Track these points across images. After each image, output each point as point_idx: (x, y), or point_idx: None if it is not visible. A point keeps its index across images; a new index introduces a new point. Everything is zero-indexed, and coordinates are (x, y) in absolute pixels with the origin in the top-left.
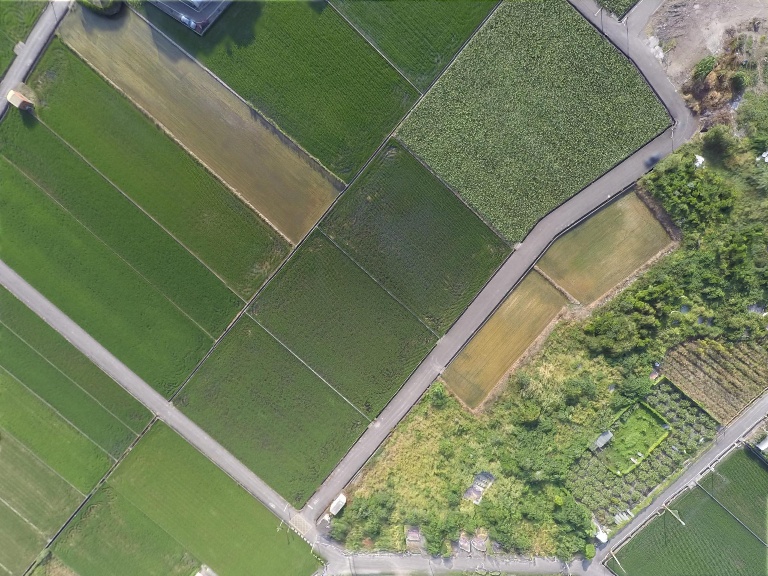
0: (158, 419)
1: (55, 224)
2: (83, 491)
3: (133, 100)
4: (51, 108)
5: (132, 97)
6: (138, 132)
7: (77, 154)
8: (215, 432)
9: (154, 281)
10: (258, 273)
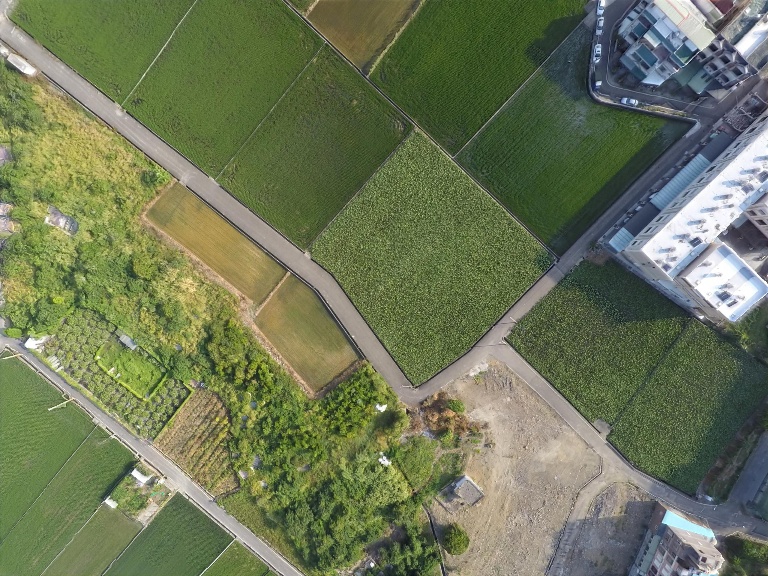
0: None
1: None
2: None
3: None
4: None
5: None
6: None
7: None
8: None
9: None
10: None
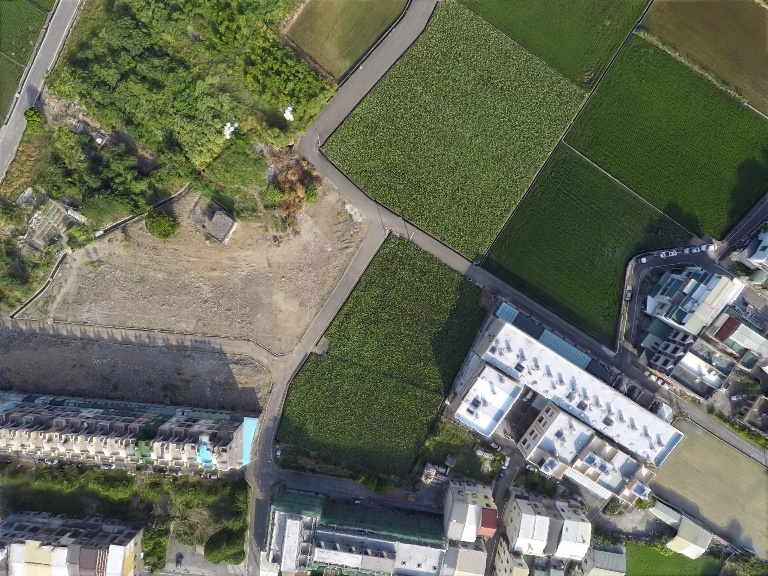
0: None
1: None
2: None
3: None
4: None
5: None
6: None
7: None
8: None
9: None
10: None
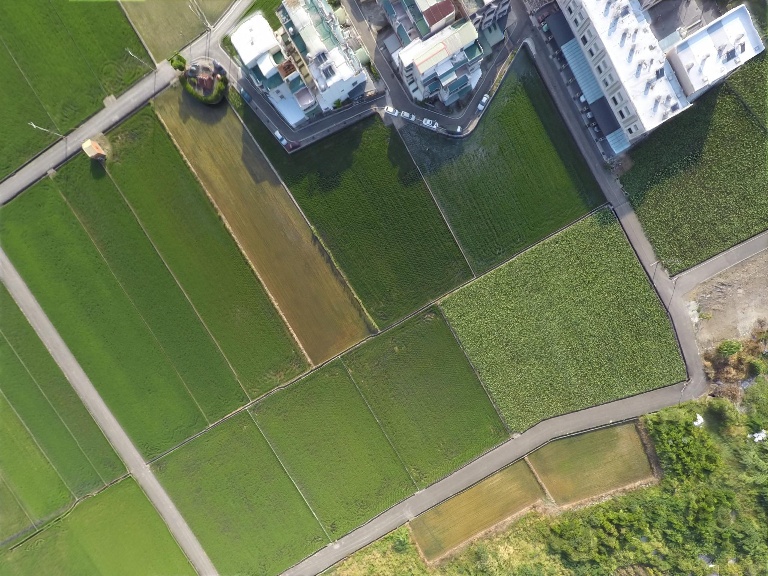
0: (130, 476)
1: (90, 269)
2: (36, 523)
3: (204, 186)
4: (122, 165)
5: (204, 183)
6: (199, 215)
7: (133, 214)
8: (181, 505)
9: (169, 352)
10: (270, 378)
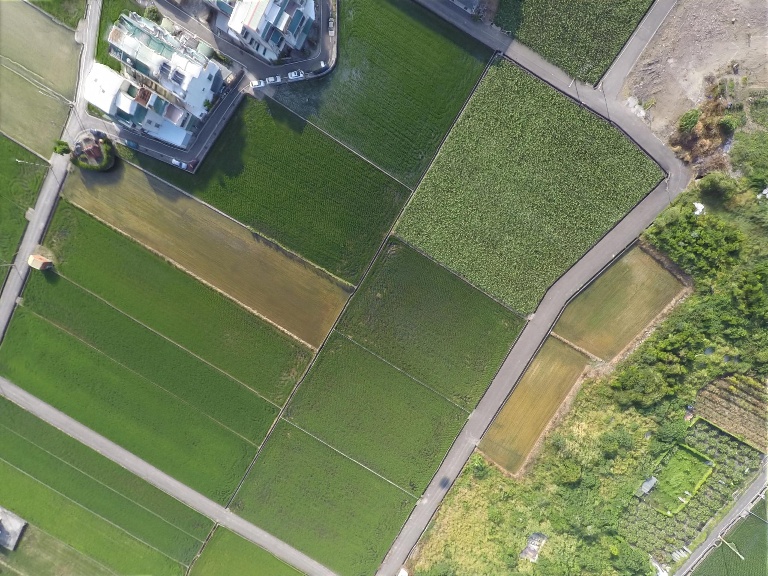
0: (219, 525)
1: (92, 365)
2: None
3: (142, 243)
4: (69, 263)
5: (140, 240)
6: (152, 271)
7: (100, 300)
8: (273, 529)
9: (192, 402)
10: (286, 380)
